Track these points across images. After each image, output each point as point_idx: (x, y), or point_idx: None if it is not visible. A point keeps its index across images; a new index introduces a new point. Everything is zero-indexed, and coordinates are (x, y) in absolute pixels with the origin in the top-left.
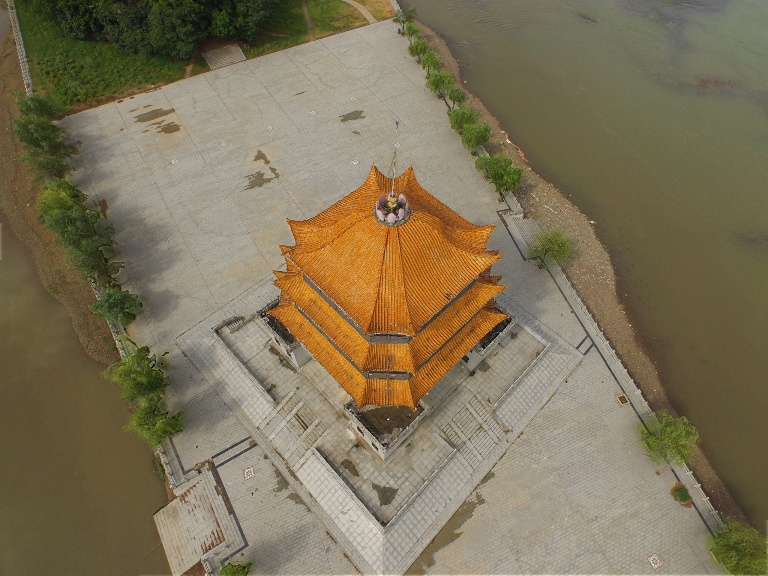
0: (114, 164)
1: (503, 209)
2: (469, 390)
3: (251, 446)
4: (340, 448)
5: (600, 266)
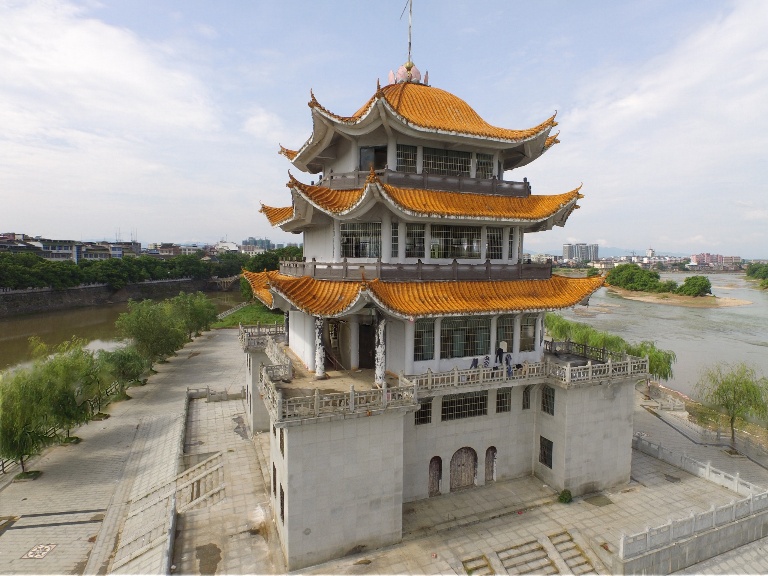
0: (230, 343)
1: (651, 405)
2: (553, 520)
3: (91, 520)
4: (220, 526)
5: None
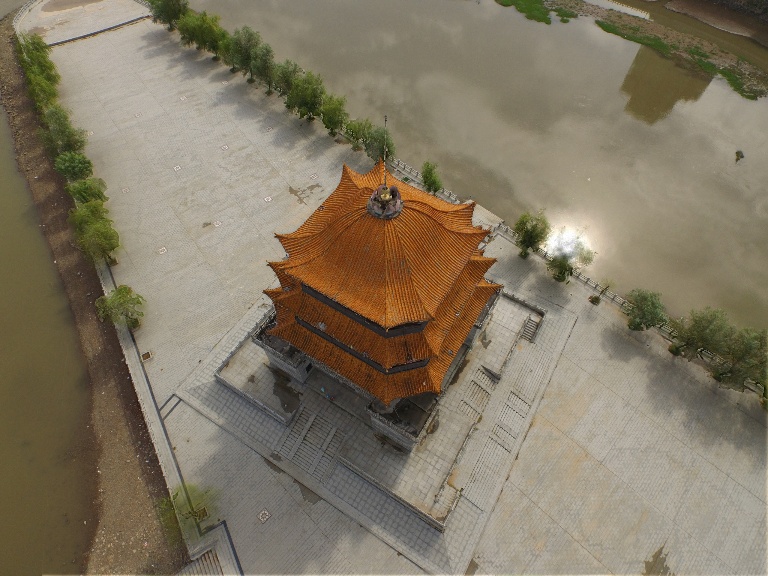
0: None
1: None
2: None
3: None
4: None
5: (106, 569)
